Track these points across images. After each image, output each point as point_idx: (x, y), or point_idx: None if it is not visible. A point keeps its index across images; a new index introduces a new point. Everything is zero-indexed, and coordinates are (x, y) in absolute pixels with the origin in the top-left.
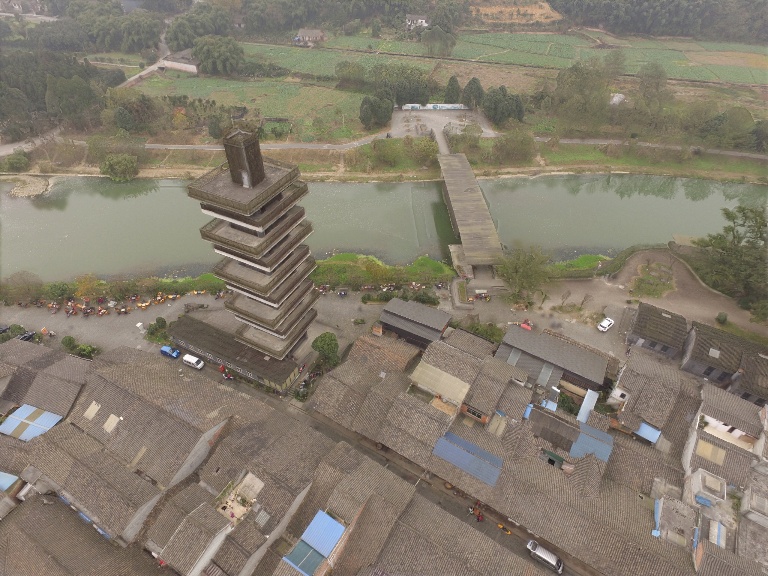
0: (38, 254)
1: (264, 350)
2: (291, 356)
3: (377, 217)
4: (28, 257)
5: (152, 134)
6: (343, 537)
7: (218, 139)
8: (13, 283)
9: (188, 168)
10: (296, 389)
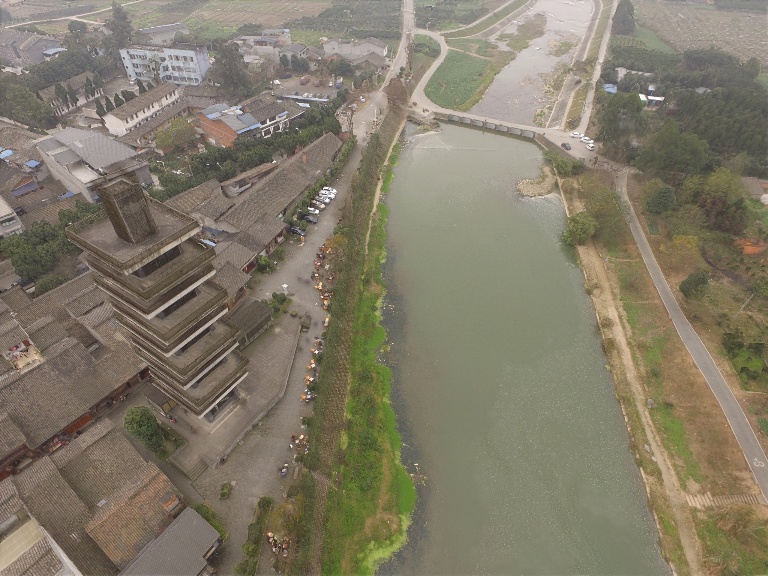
0: (428, 217)
1: None
2: None
3: (529, 566)
4: (424, 214)
5: (669, 234)
6: None
7: None
8: None
9: (611, 284)
10: None
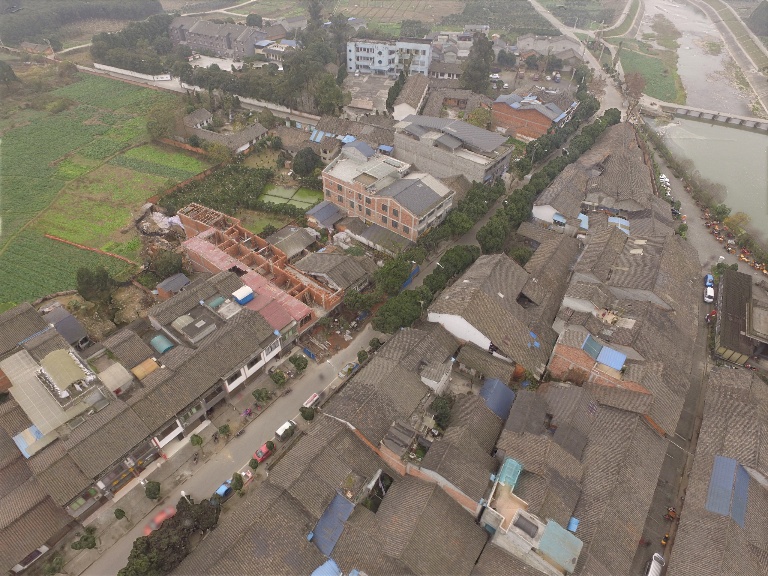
0: (749, 200)
1: (749, 322)
2: (759, 357)
3: None
4: (742, 197)
5: None
6: (612, 377)
7: None
8: (712, 189)
9: None
10: None
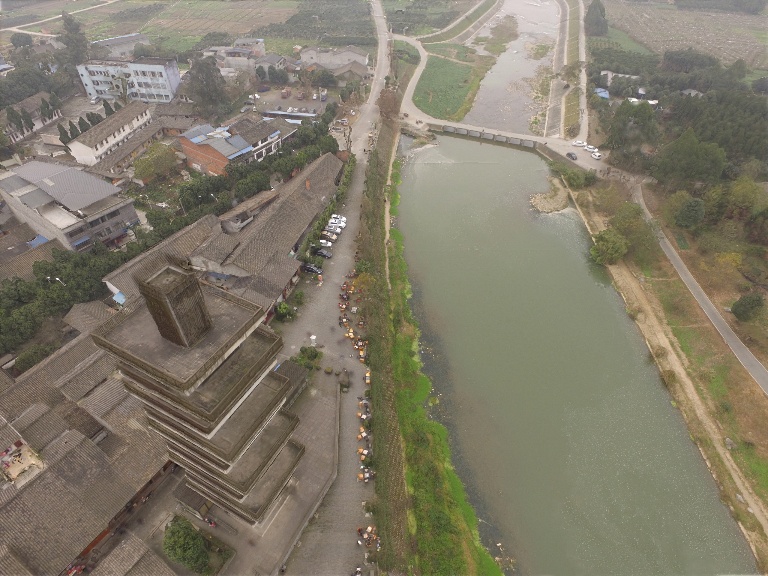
0: (446, 242)
1: None
2: None
3: None
4: (441, 238)
5: (700, 249)
6: None
7: (739, 319)
8: None
9: (653, 307)
10: (181, 517)
